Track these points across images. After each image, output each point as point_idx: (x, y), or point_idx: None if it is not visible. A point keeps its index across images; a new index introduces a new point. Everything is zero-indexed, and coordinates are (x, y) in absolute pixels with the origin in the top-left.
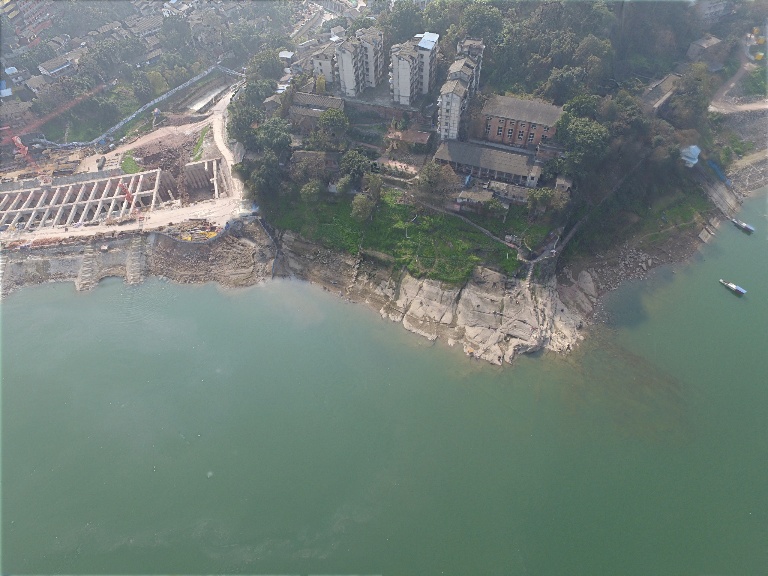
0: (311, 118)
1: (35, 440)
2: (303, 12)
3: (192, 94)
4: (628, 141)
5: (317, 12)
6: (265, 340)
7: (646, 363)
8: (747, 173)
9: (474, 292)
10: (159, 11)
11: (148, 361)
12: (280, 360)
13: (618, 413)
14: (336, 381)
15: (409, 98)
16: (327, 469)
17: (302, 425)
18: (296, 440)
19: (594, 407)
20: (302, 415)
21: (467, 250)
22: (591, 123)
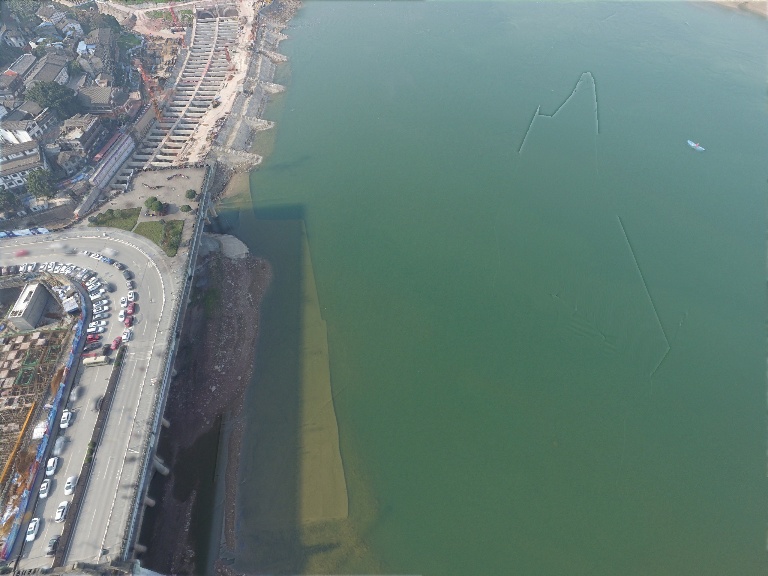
0: None
1: None
2: None
3: None
4: None
5: None
6: None
7: None
8: None
9: None
10: None
11: (339, 16)
12: None
13: None
14: None
15: None
16: None
17: None
18: None
19: None
20: None
21: None
22: None
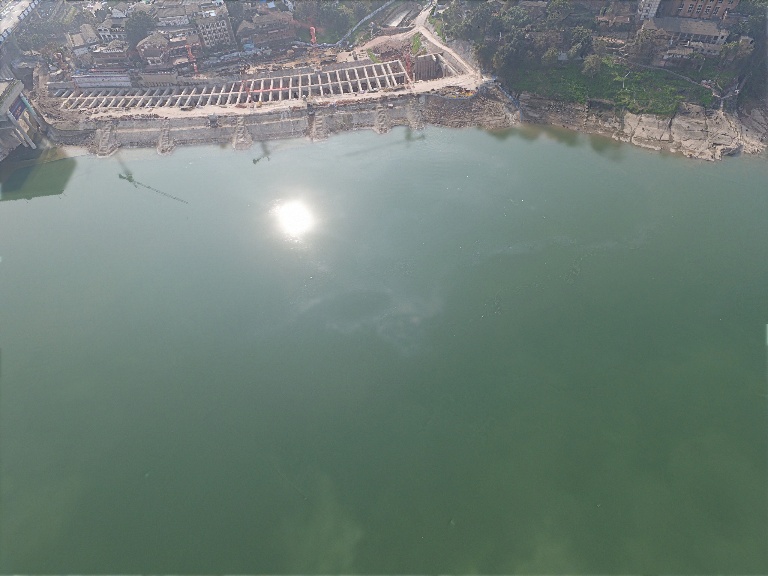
0: (537, 8)
1: (409, 206)
2: None
3: (389, 15)
4: None
5: None
6: (537, 154)
7: None
8: None
9: (682, 120)
10: None
11: (461, 166)
12: (555, 164)
13: None
14: (603, 171)
15: None
16: (622, 212)
17: (592, 193)
18: (592, 199)
19: None
20: (589, 188)
21: (674, 92)
22: None
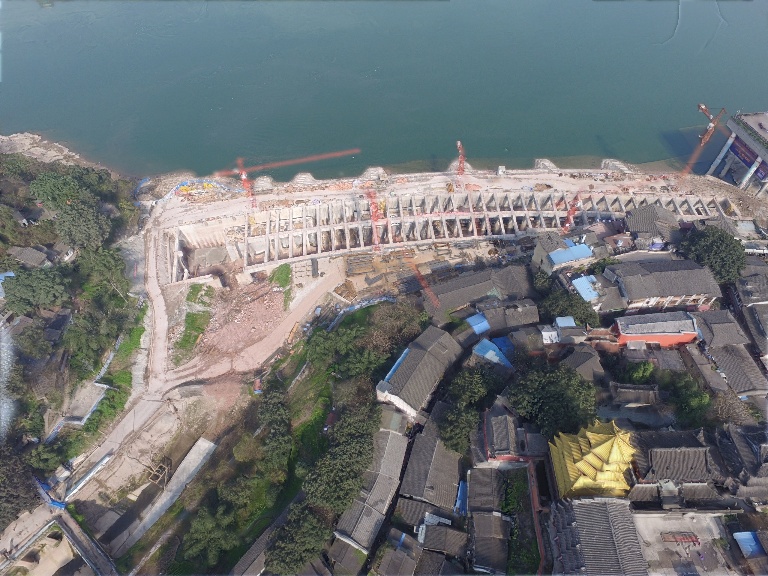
0: None
1: (301, 108)
2: None
3: None
4: None
5: None
6: (166, 145)
7: None
8: None
9: (1, 152)
10: None
11: (243, 134)
12: (159, 136)
13: None
14: (128, 124)
15: None
16: (148, 100)
17: (155, 111)
18: (160, 107)
19: None
20: (154, 115)
21: None
22: None
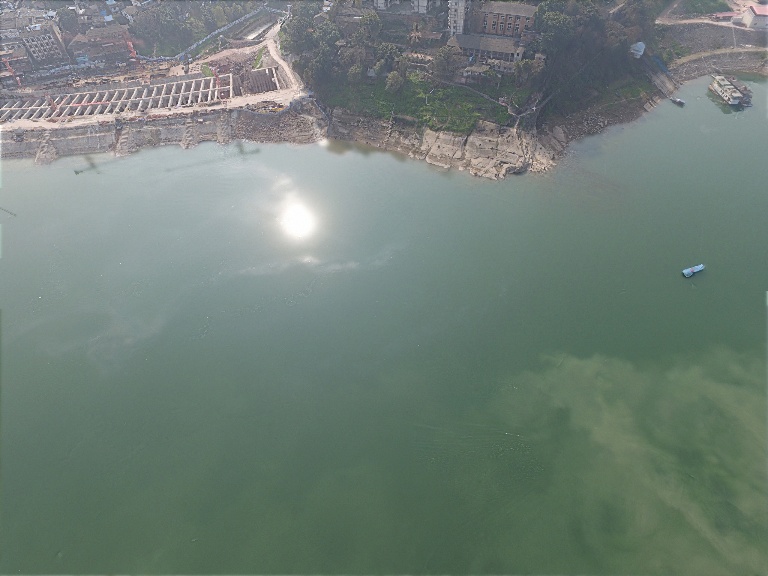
0: (352, 24)
1: (176, 224)
2: None
3: (246, 27)
4: (588, 31)
5: None
6: (327, 171)
7: (599, 176)
8: (684, 68)
9: (477, 137)
10: None
11: (245, 183)
12: (340, 181)
13: (578, 202)
14: (381, 189)
15: (426, 7)
16: (380, 232)
17: (360, 212)
18: (357, 219)
19: (561, 199)
20: (359, 207)
21: (471, 109)
22: (560, 15)
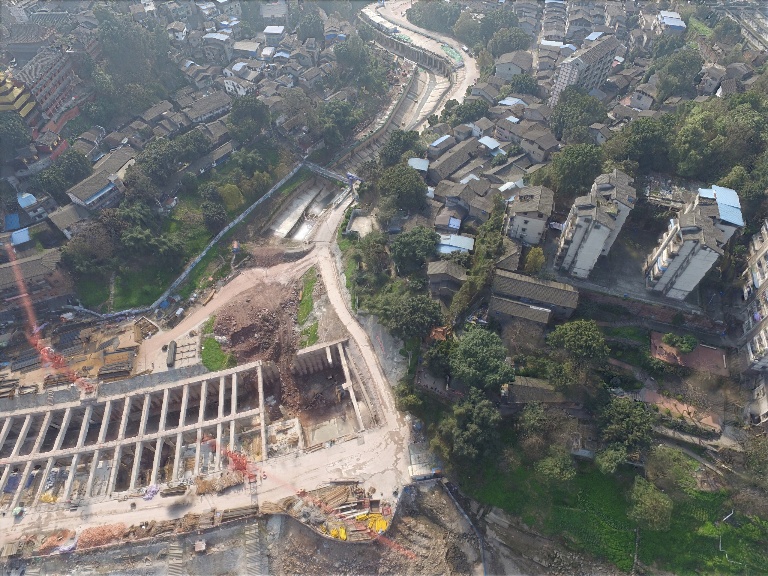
0: (528, 321)
1: None
2: (395, 72)
3: (277, 209)
4: None
5: (413, 72)
6: None
7: None
8: None
9: None
10: (219, 81)
11: None
12: None
13: None
14: None
15: (688, 293)
16: None
17: None
18: None
19: None
20: None
21: None
22: None
